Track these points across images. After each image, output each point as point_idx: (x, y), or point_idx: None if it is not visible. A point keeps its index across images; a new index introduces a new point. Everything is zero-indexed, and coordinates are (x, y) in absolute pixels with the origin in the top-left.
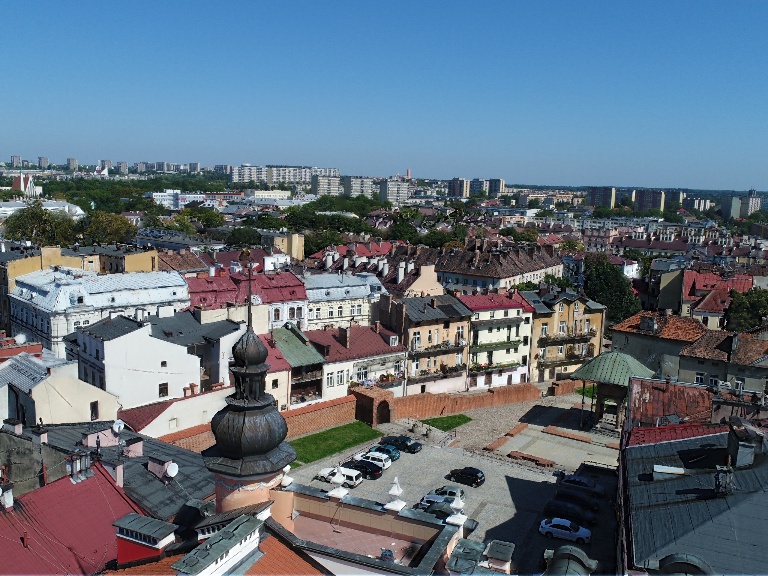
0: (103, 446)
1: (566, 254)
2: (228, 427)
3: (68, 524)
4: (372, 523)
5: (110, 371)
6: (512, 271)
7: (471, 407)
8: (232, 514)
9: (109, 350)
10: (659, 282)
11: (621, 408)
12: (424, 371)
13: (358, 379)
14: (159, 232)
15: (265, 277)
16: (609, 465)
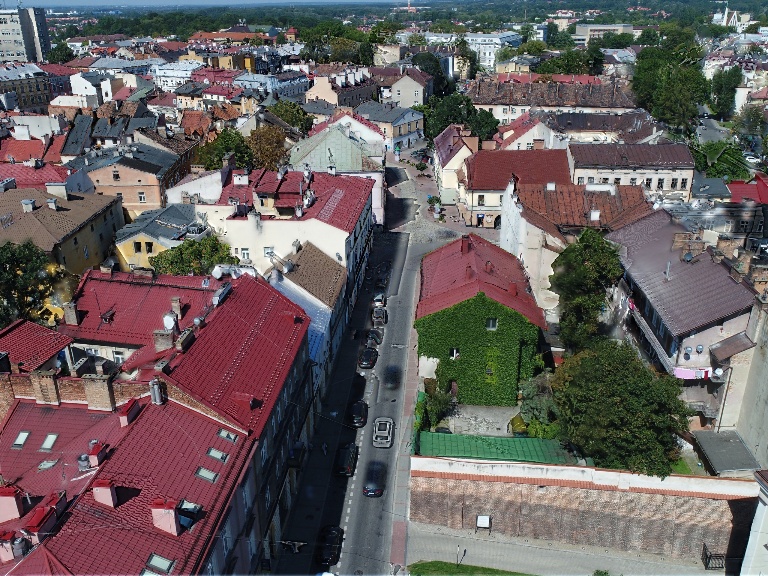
0: None
1: None
2: None
3: None
4: None
5: None
6: None
7: None
8: None
9: (71, 79)
10: None
11: None
12: None
13: None
14: None
15: None
16: None
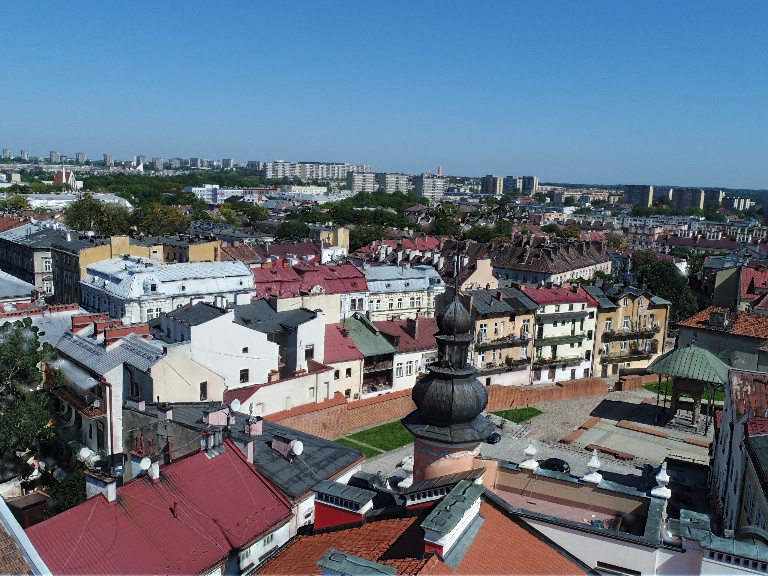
0: (221, 425)
1: (612, 251)
2: (437, 394)
3: (210, 497)
4: (567, 495)
5: (196, 356)
6: (563, 267)
7: (540, 400)
8: (443, 480)
9: (195, 335)
10: (712, 280)
11: (698, 403)
12: (490, 364)
13: (426, 370)
14: (209, 225)
15: (327, 268)
16: (694, 459)
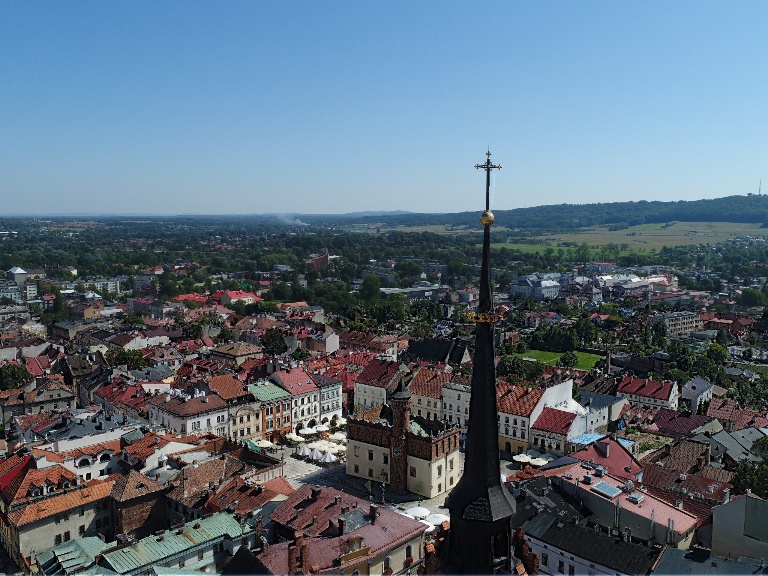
0: None
1: None
2: None
3: None
4: None
5: None
6: None
7: None
8: None
9: None
10: None
11: None
12: None
13: None
14: None
15: None
16: None
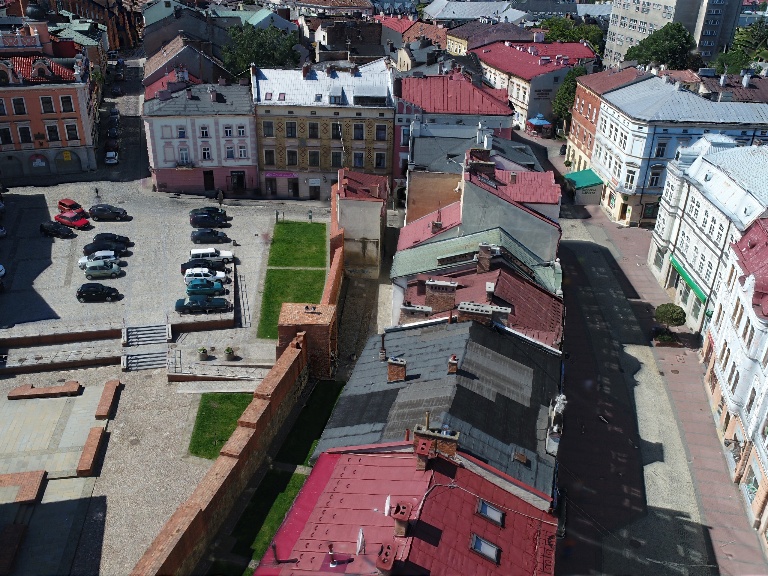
0: None
1: None
2: None
3: None
4: None
5: None
6: None
7: None
8: None
9: None
10: None
11: None
12: None
13: None
14: None
15: None
16: None
